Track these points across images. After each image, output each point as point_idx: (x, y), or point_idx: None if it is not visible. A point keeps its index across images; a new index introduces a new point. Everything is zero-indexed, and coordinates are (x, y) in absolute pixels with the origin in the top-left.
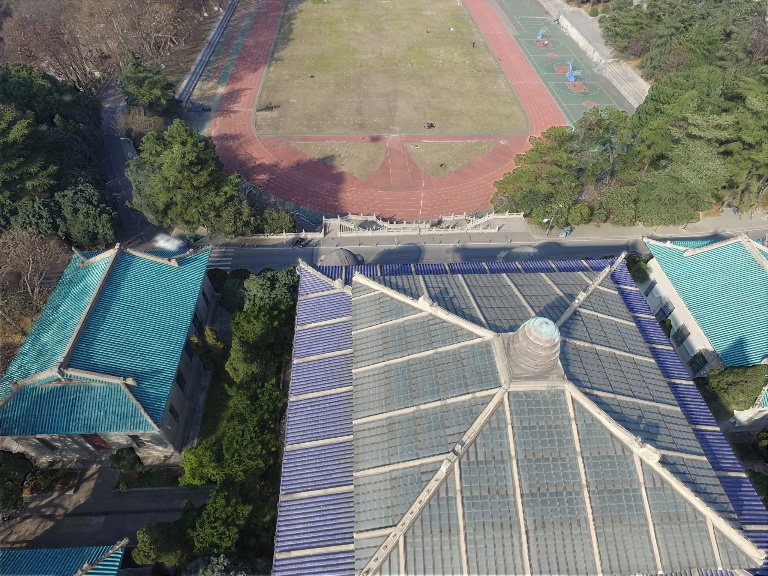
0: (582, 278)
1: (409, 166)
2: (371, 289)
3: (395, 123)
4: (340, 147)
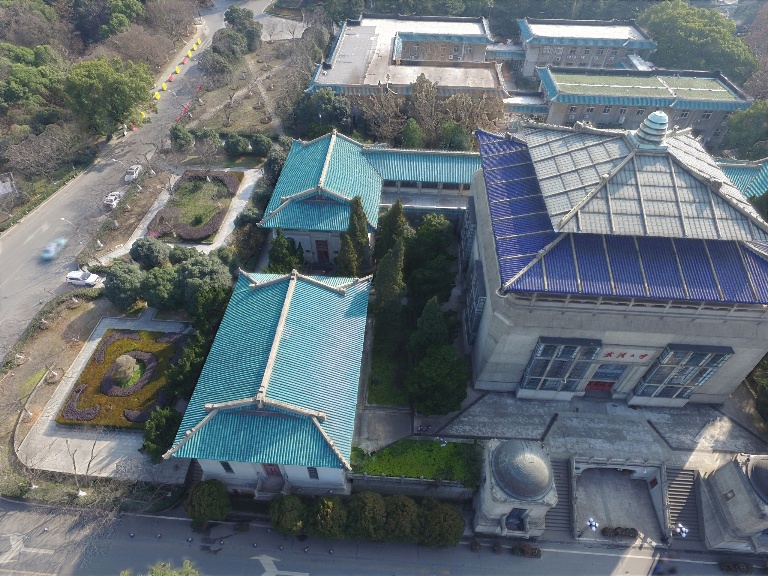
0: (582, 221)
1: None
2: None
3: None
4: None
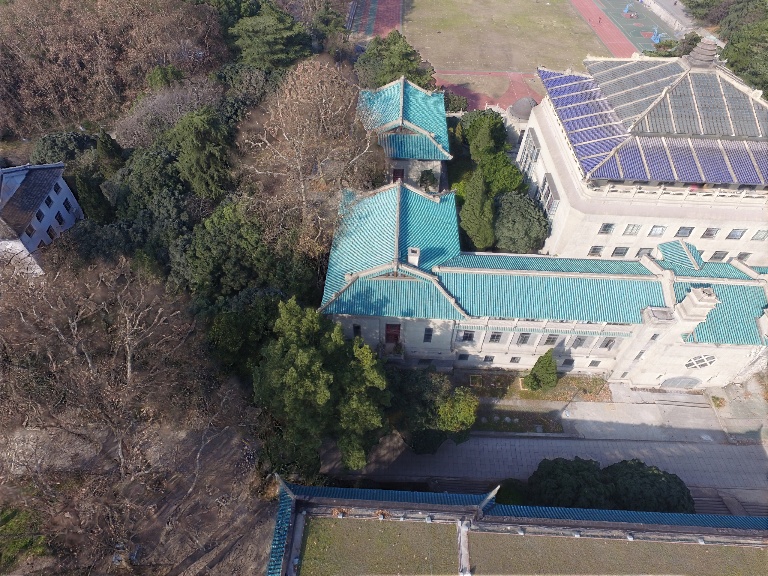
0: None
1: (529, 92)
2: (597, 61)
3: (513, 65)
4: (473, 78)
